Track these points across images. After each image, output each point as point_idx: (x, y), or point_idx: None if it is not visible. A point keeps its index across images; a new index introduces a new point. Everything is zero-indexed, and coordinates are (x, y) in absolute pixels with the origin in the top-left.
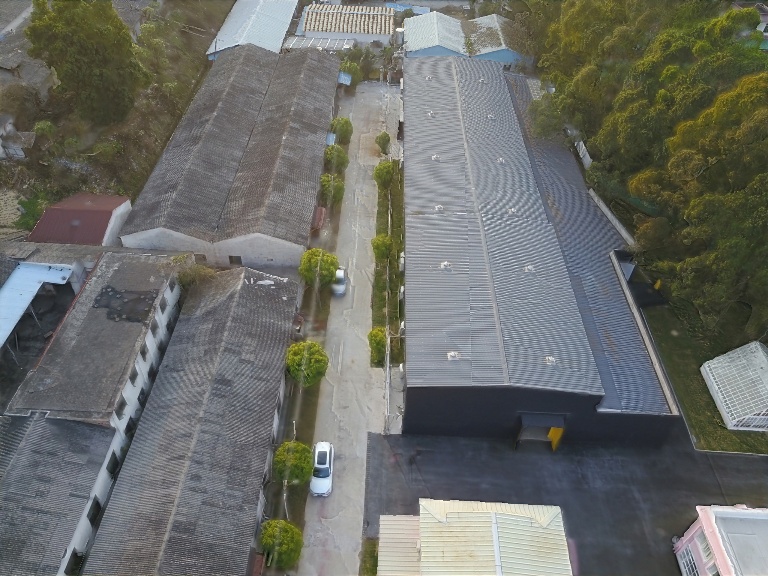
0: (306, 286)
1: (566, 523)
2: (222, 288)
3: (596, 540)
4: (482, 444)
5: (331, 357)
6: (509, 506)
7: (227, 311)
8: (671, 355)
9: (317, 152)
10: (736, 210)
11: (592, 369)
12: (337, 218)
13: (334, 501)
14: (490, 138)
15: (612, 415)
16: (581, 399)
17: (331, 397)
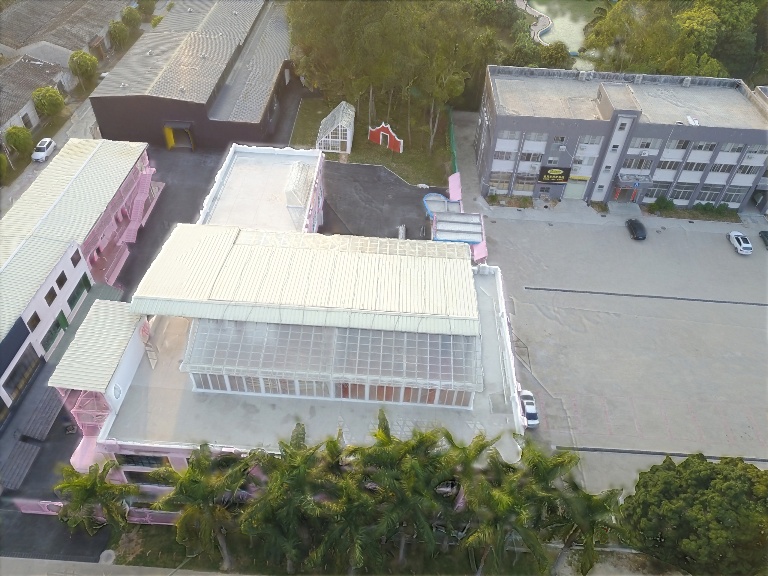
0: (75, 76)
1: (179, 177)
2: (7, 64)
3: (192, 183)
4: (151, 148)
5: (79, 112)
6: (119, 141)
7: (3, 71)
8: (307, 121)
9: (115, 10)
10: (302, 3)
11: (206, 94)
12: (124, 53)
13: (46, 165)
14: (237, 2)
15: (218, 122)
16: (194, 108)
17: (69, 128)
